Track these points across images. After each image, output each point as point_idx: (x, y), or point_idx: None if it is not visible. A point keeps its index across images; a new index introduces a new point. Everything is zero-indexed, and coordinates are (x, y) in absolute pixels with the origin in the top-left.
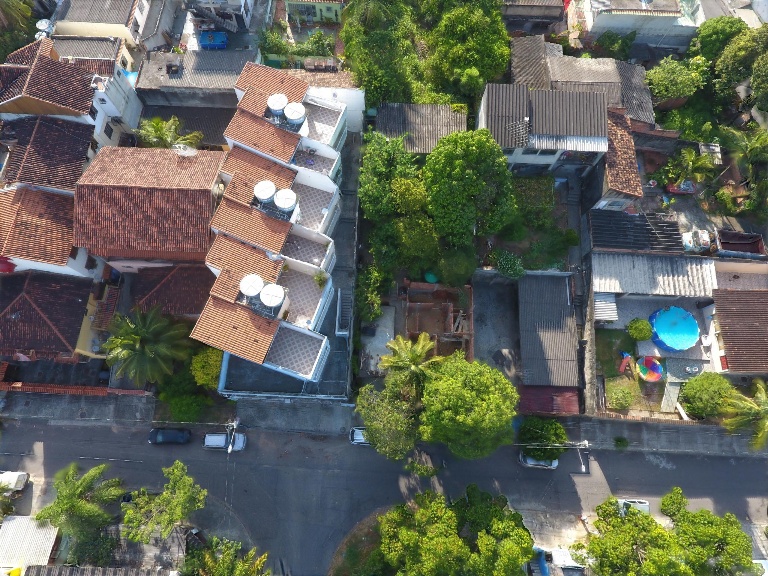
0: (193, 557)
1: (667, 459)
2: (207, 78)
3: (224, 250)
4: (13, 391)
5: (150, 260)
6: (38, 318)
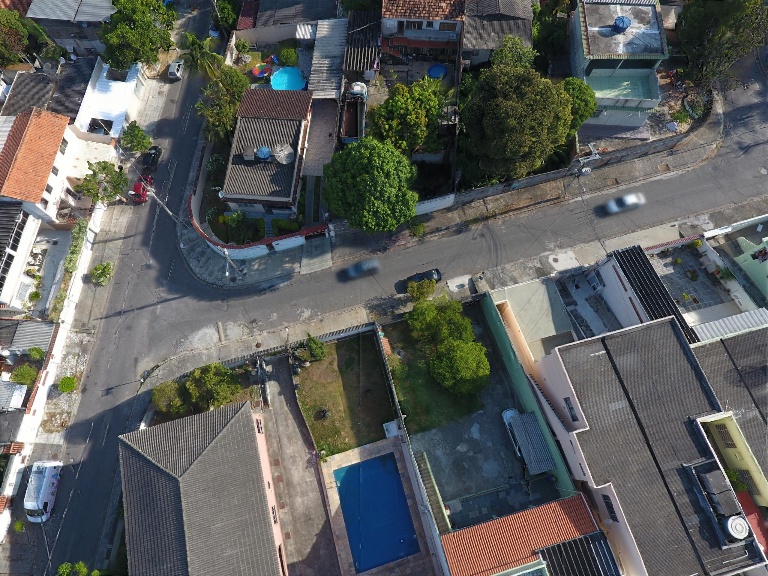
0: None
1: (204, 100)
2: None
3: None
4: None
5: None
6: None
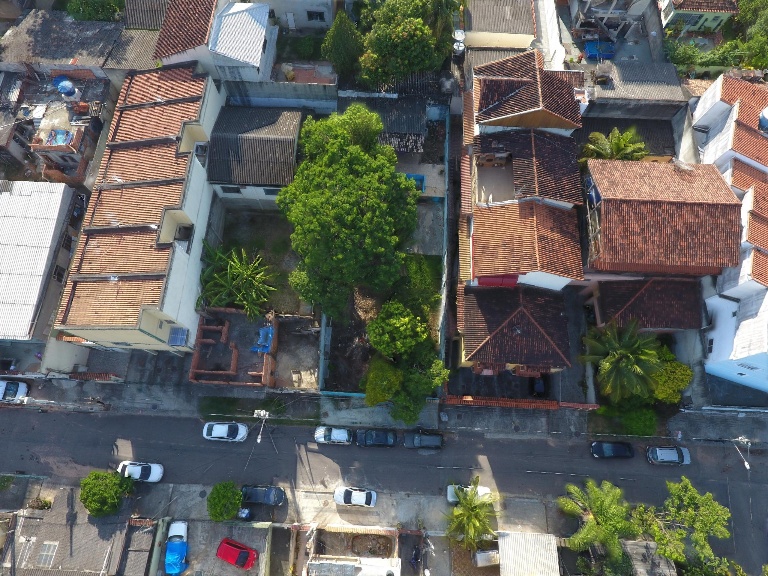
0: (693, 574)
1: None
2: (640, 89)
3: (762, 265)
4: (443, 404)
5: (621, 273)
6: (536, 332)
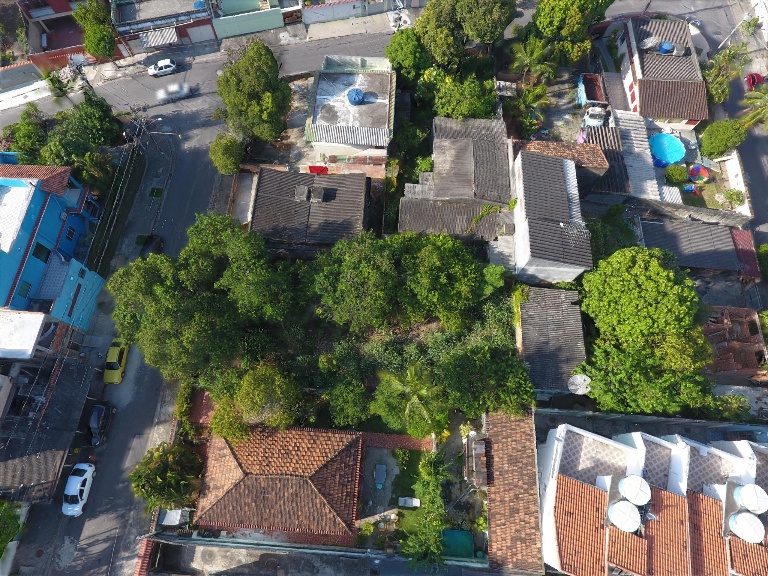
0: None
1: None
2: None
3: None
4: None
5: None
6: None
